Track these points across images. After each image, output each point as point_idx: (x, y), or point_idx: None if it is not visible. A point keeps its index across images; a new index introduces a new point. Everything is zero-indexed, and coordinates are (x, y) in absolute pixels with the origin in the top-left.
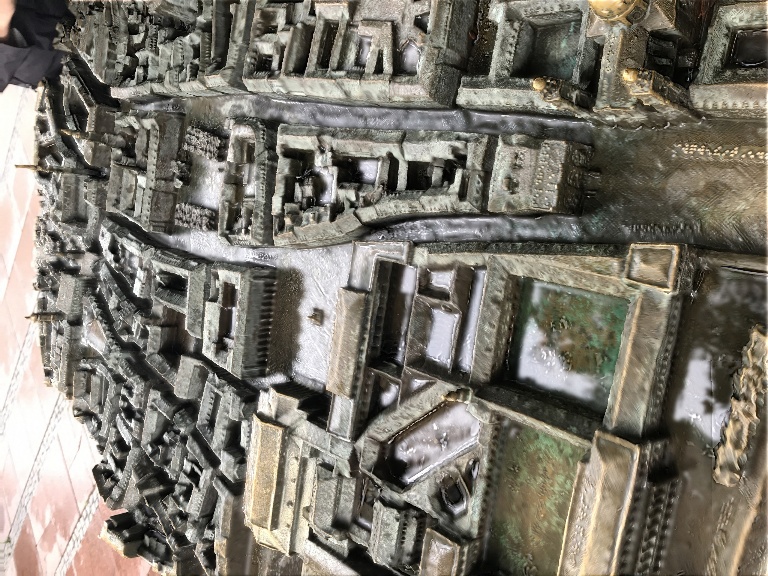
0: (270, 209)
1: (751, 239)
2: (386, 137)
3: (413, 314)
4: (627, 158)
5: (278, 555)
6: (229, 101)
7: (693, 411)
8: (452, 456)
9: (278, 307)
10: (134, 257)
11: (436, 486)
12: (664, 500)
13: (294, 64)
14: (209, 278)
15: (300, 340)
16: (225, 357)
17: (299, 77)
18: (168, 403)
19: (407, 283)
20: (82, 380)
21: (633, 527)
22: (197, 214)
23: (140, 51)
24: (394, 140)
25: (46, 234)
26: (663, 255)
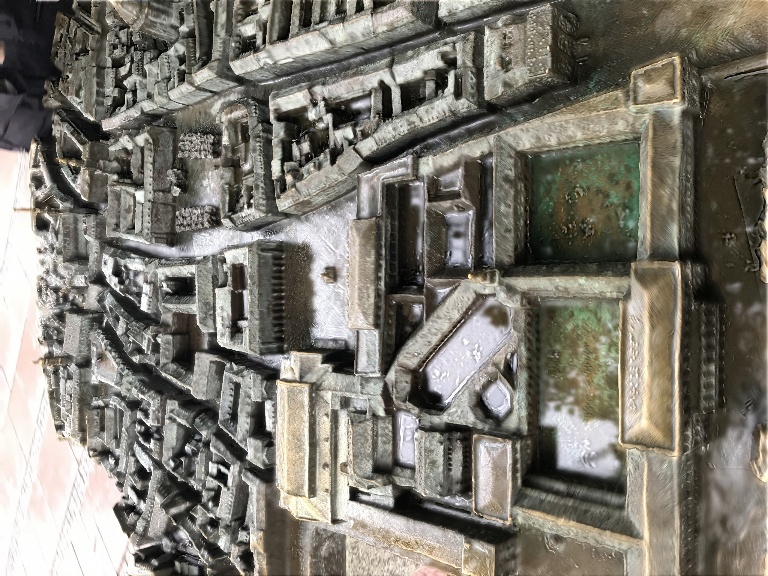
0: (270, 180)
1: (748, 47)
2: (375, 67)
3: (426, 224)
4: (612, 17)
5: (319, 543)
6: (218, 100)
7: (726, 231)
8: None
9: (289, 280)
10: (138, 276)
11: (476, 395)
12: (715, 324)
13: (278, 33)
14: (216, 270)
15: (315, 305)
16: (241, 338)
17: (284, 41)
18: (187, 410)
19: (416, 207)
20: (95, 419)
21: (689, 356)
22: (198, 214)
23: (128, 78)
24: (384, 66)
25: (48, 289)
26: (665, 70)
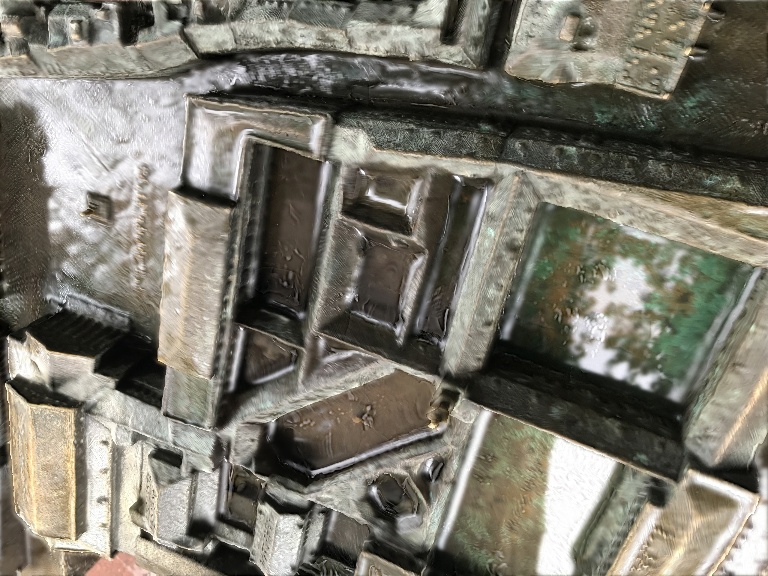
0: None
1: None
2: None
3: (331, 248)
4: None
5: None
6: None
7: None
8: (390, 447)
9: (7, 181)
10: None
11: (365, 487)
12: None
13: None
14: None
15: (67, 243)
16: None
17: None
18: None
19: (295, 174)
20: None
21: None
22: None
23: None
24: None
25: None
26: None
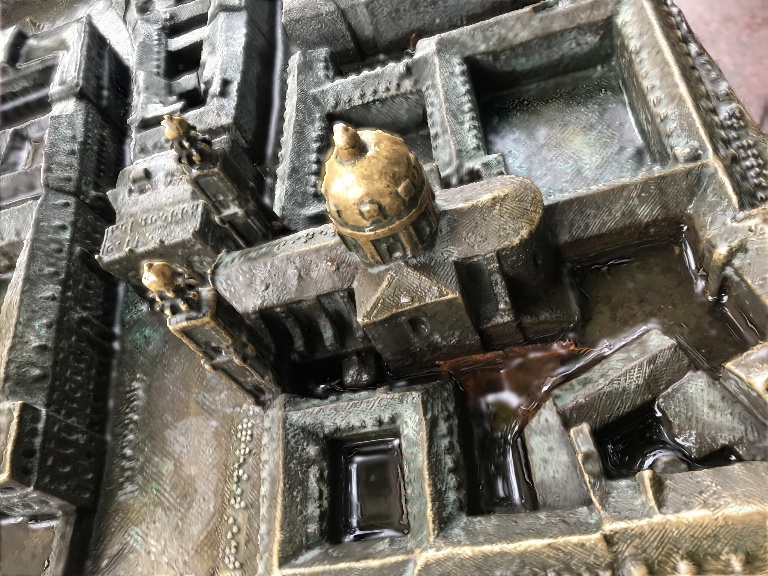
0: None
1: None
2: None
3: None
4: None
5: None
6: None
7: None
8: None
9: None
10: None
11: None
12: None
13: None
14: None
15: None
16: None
17: None
18: None
19: None
20: None
21: None
22: None
23: None
24: None
25: None
26: None
